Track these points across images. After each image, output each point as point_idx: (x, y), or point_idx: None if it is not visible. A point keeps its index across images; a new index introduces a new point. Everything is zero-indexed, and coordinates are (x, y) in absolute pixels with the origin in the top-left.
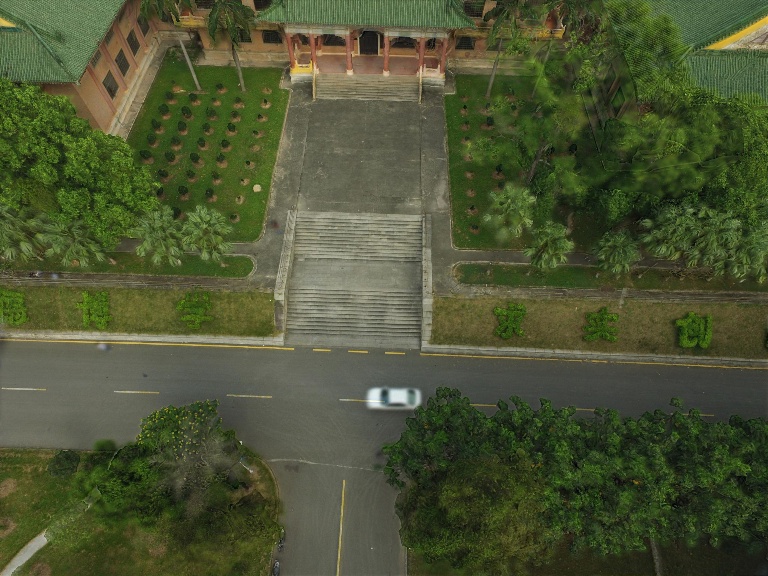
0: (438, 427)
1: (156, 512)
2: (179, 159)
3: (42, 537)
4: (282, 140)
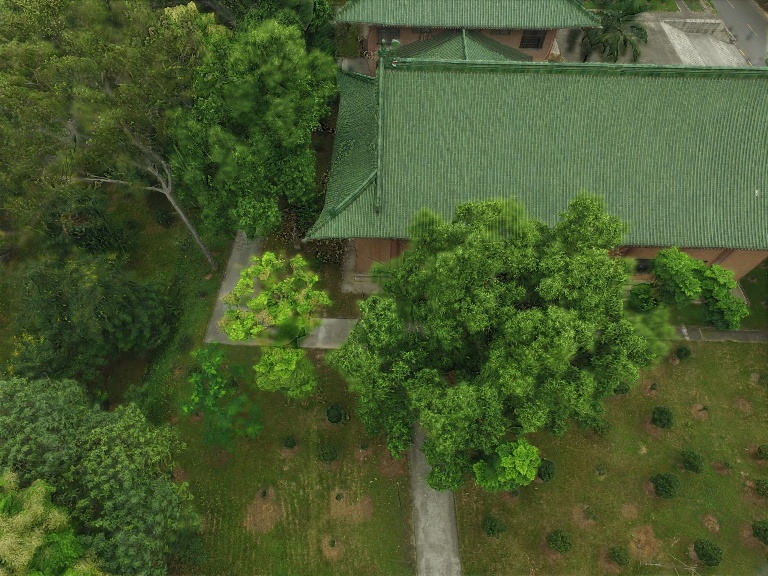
0: None
1: None
2: None
3: None
4: None
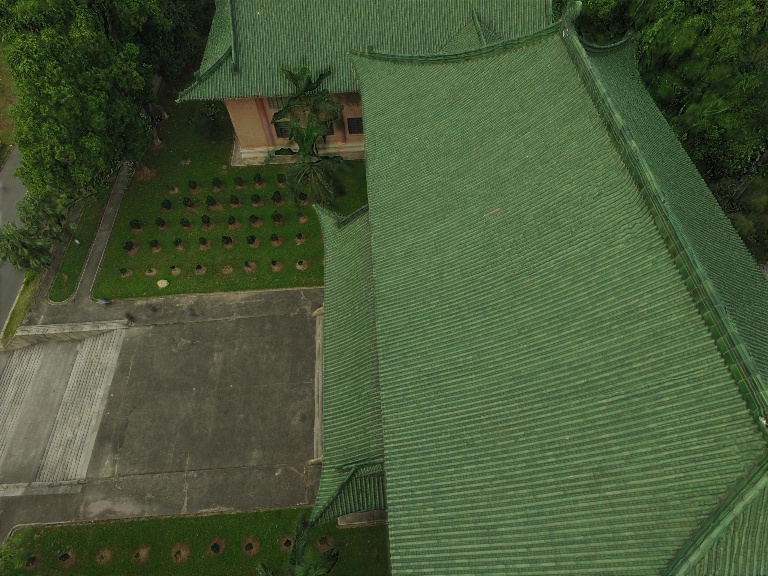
0: None
1: None
2: (217, 210)
3: None
4: (241, 293)
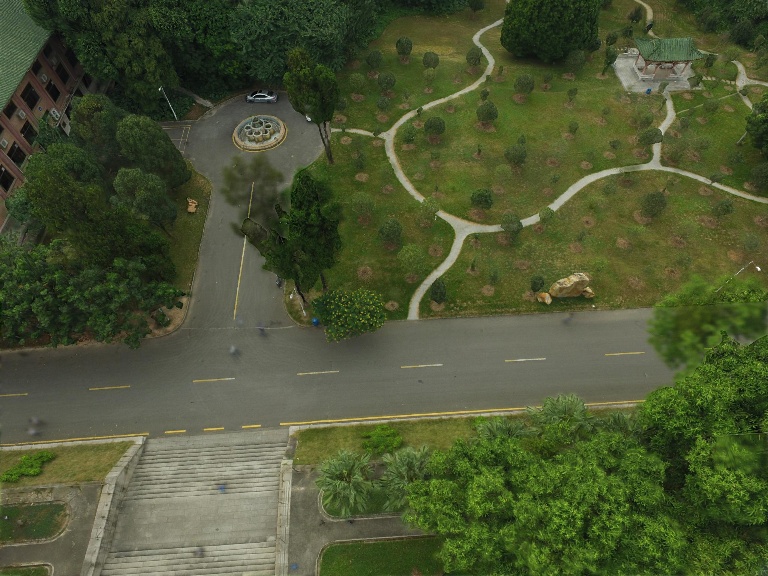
0: (111, 282)
1: (372, 287)
2: None
3: (445, 268)
4: None
